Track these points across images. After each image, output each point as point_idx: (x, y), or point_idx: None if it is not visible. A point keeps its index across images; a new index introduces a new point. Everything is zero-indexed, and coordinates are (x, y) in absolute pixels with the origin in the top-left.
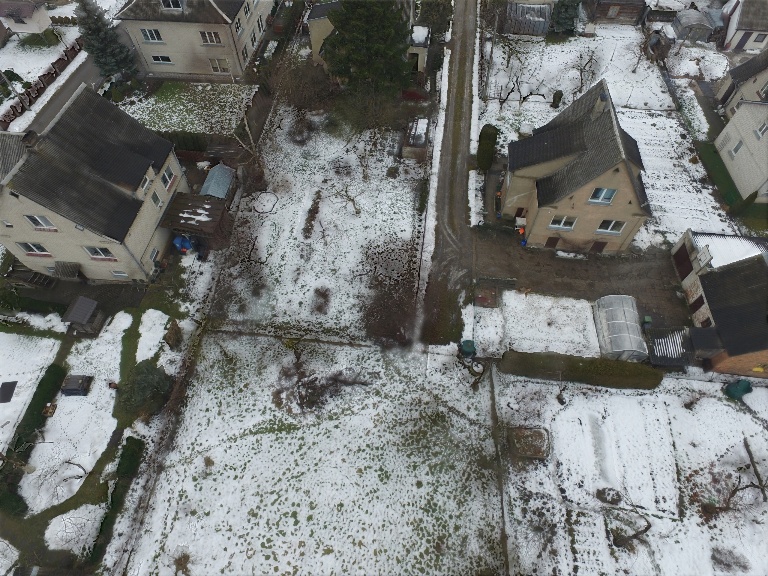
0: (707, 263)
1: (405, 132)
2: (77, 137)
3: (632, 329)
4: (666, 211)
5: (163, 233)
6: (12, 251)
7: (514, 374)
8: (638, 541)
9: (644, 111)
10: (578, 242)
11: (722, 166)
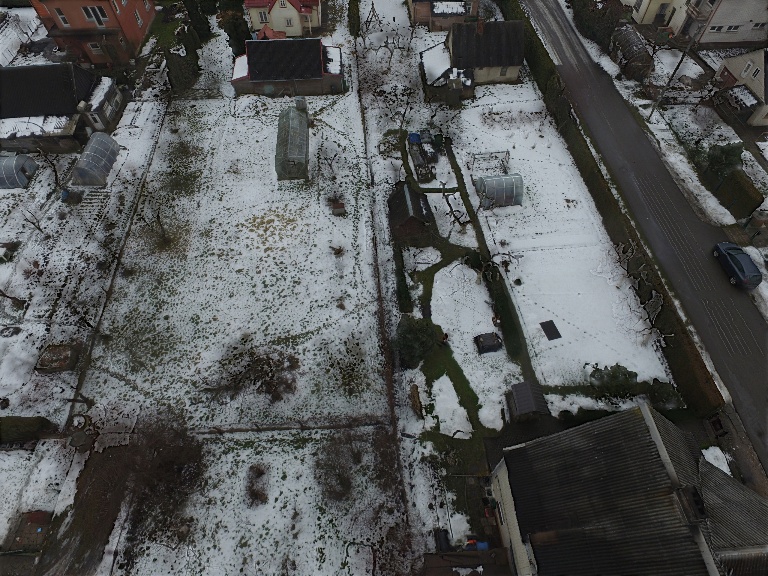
0: None
1: None
2: None
3: None
4: None
5: None
6: None
7: None
8: (7, 307)
9: None
10: None
11: None
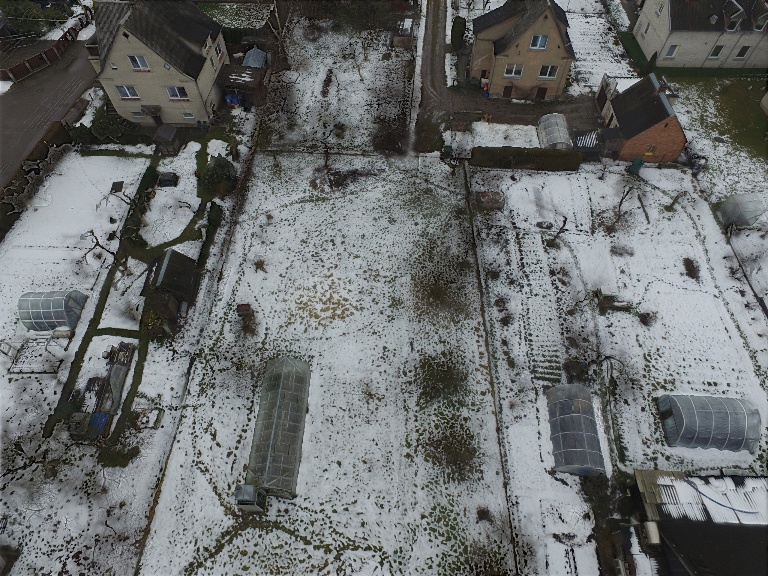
0: (615, 89)
1: (395, 28)
2: (160, 6)
3: (562, 131)
4: (593, 74)
5: (217, 92)
6: (110, 96)
7: (480, 166)
8: (563, 245)
9: (581, 14)
10: (526, 89)
11: (637, 46)
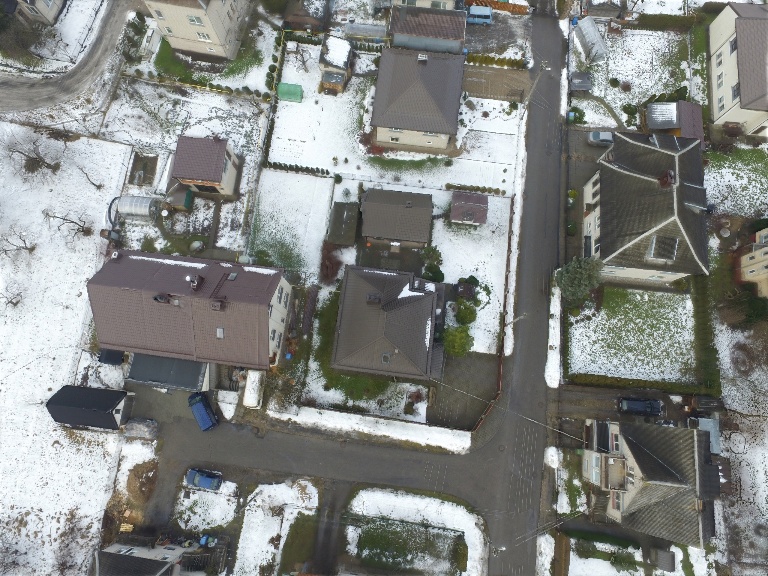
0: None
1: None
2: None
3: None
4: None
5: None
6: None
7: None
8: None
9: None
10: None
11: None
